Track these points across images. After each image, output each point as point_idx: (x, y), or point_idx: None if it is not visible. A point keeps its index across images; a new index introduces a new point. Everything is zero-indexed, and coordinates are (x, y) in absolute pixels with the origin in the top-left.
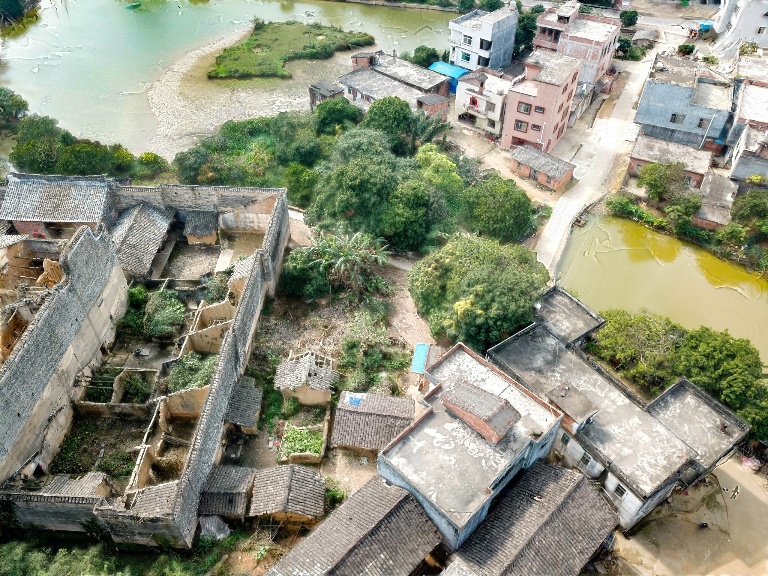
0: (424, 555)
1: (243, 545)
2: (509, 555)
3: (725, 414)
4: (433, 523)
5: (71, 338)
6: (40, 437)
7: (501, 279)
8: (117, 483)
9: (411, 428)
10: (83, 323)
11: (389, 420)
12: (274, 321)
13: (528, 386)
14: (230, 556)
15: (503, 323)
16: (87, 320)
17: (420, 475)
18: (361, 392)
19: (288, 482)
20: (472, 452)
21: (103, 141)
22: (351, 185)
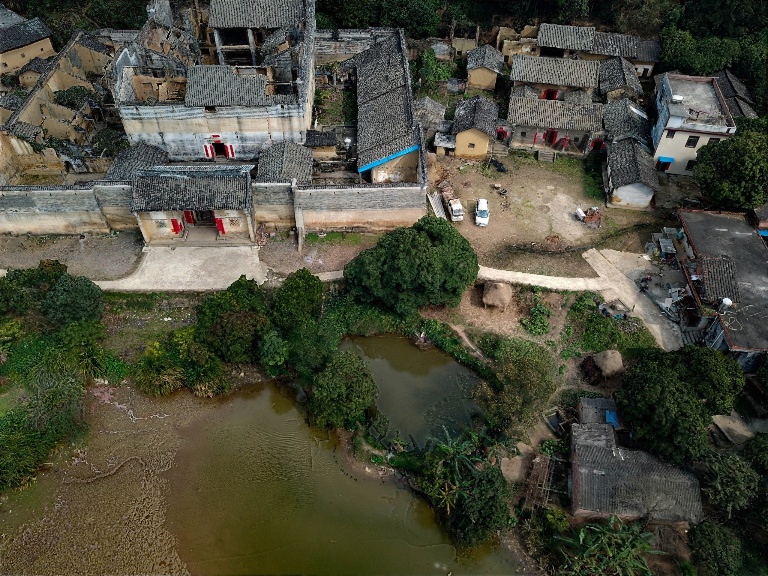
0: None
1: None
2: None
3: None
4: None
5: None
6: None
7: None
8: None
9: None
10: None
11: None
12: None
13: None
14: None
15: None
16: None
17: None
18: None
19: (32, 63)
20: None
21: (262, 449)
22: None
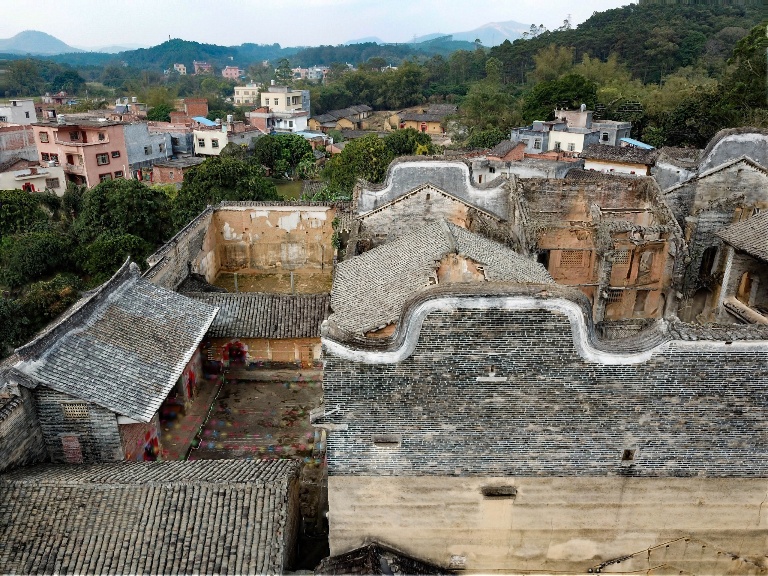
0: None
1: None
2: None
3: (463, 150)
4: None
5: None
6: None
7: (404, 132)
8: None
9: None
10: None
11: None
12: None
13: None
14: None
15: None
16: None
17: None
18: None
19: None
20: None
21: None
22: (243, 170)
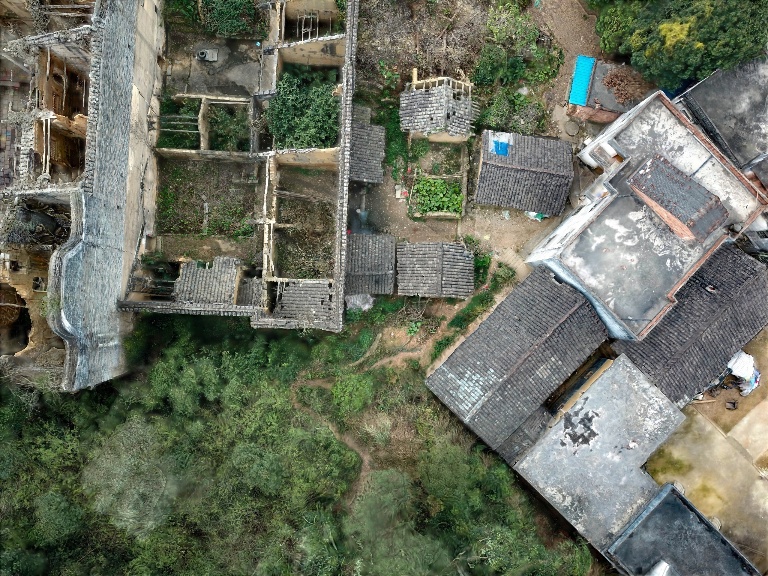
0: (590, 352)
1: (394, 322)
2: (674, 351)
3: None
4: (602, 321)
5: (131, 75)
6: (139, 210)
7: None
8: (236, 245)
9: (592, 221)
10: (135, 44)
11: (544, 178)
12: (376, 1)
13: (728, 149)
14: (383, 333)
15: (725, 62)
16: (137, 36)
17: (598, 278)
18: (503, 127)
19: (440, 265)
20: (657, 250)
21: None
22: None
